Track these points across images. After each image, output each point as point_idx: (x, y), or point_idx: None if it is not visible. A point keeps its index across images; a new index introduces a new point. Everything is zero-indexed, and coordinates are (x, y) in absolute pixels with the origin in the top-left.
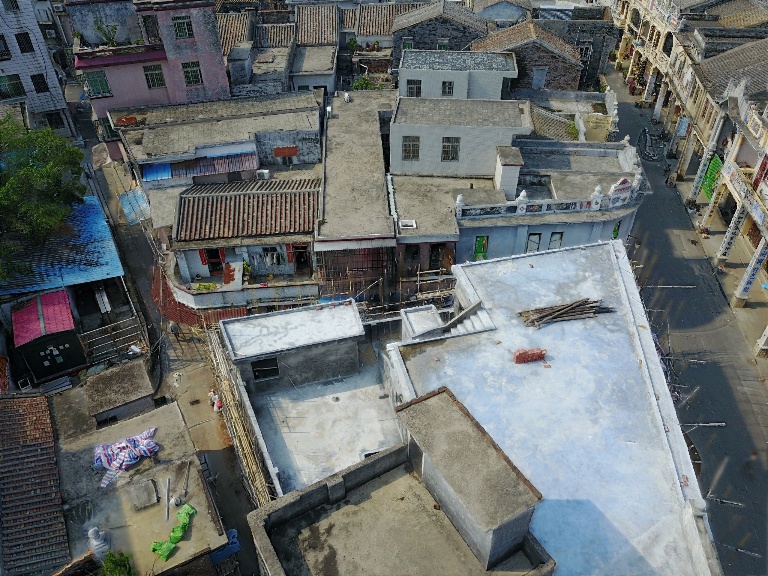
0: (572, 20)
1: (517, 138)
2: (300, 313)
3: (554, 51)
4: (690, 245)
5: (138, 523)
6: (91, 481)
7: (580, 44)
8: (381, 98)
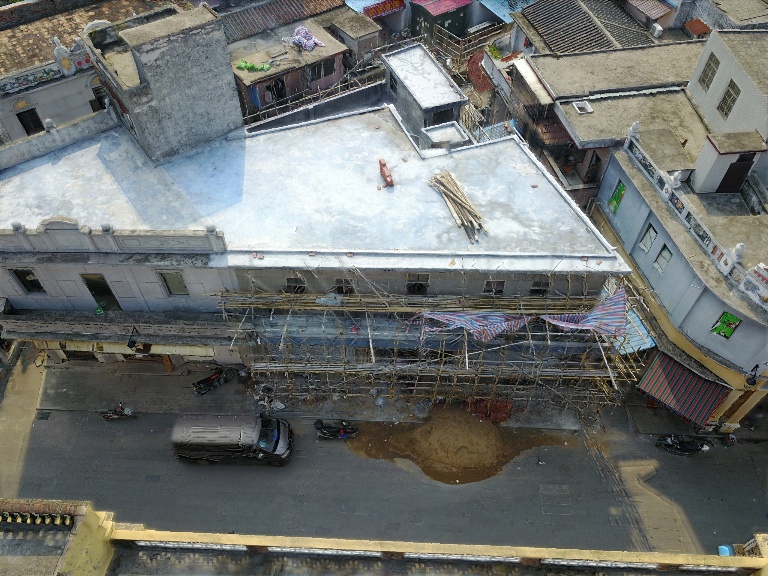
0: None
1: None
2: (443, 77)
3: None
4: None
5: (259, 55)
6: (286, 34)
7: None
8: None
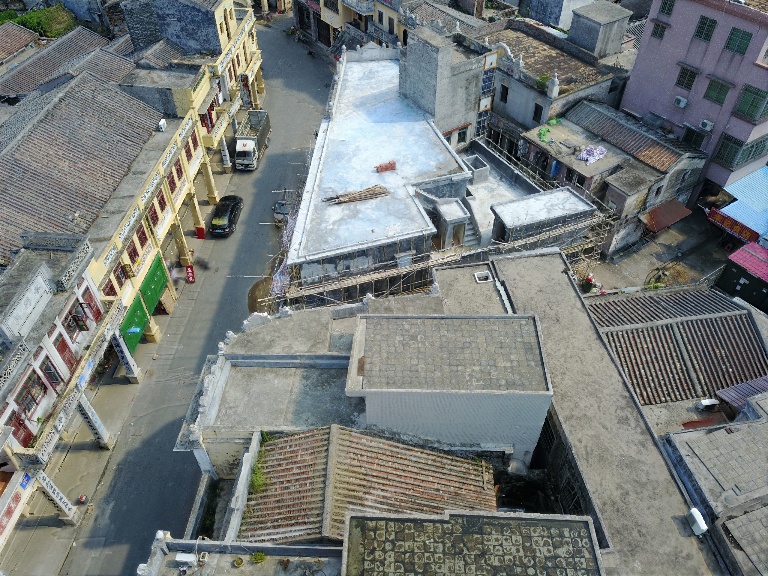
0: None
1: None
2: None
3: None
4: (76, 574)
5: (563, 136)
6: None
7: None
8: None
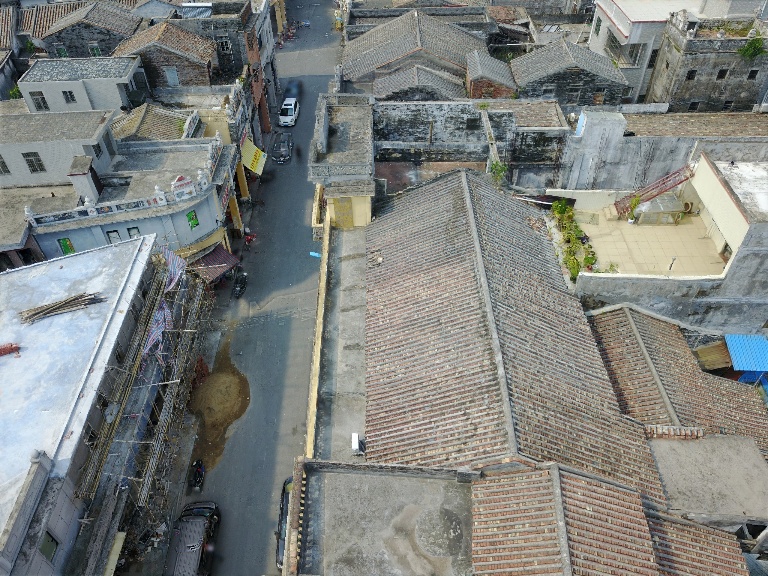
0: (203, 18)
1: (122, 141)
2: None
3: (175, 52)
4: None
5: None
6: None
7: (218, 39)
8: (26, 107)
